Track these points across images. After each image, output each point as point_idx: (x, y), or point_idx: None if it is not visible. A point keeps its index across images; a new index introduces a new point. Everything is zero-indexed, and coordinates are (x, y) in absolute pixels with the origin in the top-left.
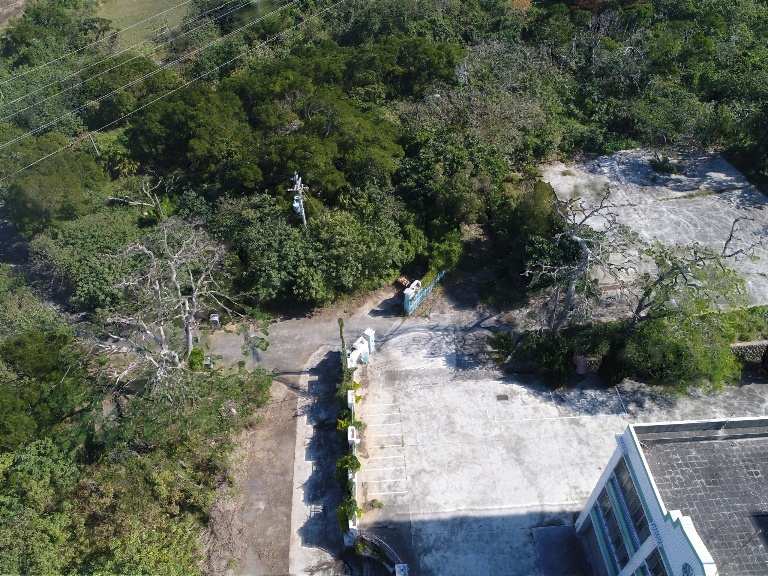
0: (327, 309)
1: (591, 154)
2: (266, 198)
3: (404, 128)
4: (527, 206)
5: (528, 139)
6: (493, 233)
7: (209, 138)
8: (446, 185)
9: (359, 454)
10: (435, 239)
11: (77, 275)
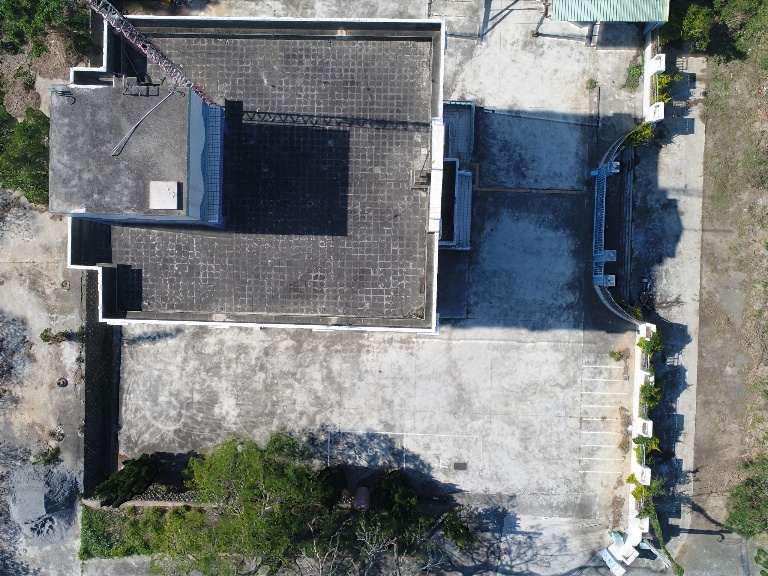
0: None
1: None
2: None
3: None
4: None
5: None
6: None
7: None
8: None
9: (630, 413)
10: None
11: None
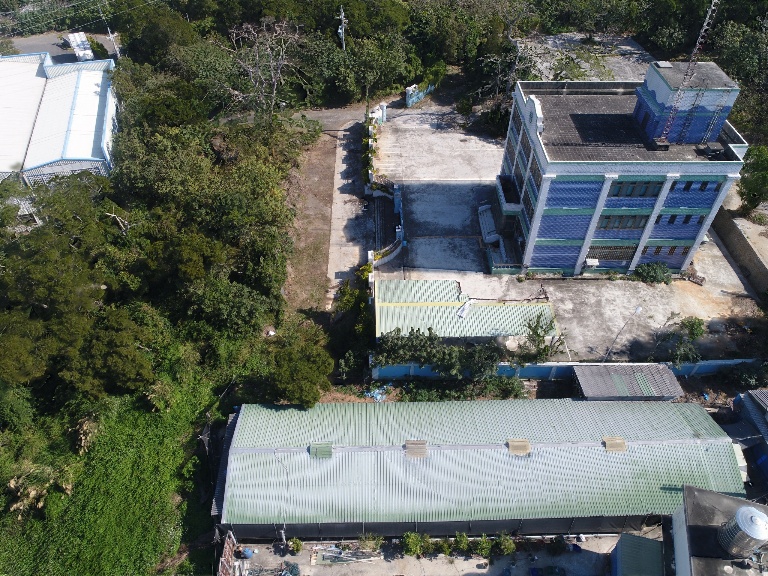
0: (355, 104)
1: (542, 34)
2: (318, 35)
3: (412, 14)
4: (489, 43)
5: (497, 17)
6: (468, 70)
7: (276, 10)
8: (437, 27)
9: (375, 158)
10: (428, 67)
11: (196, 71)
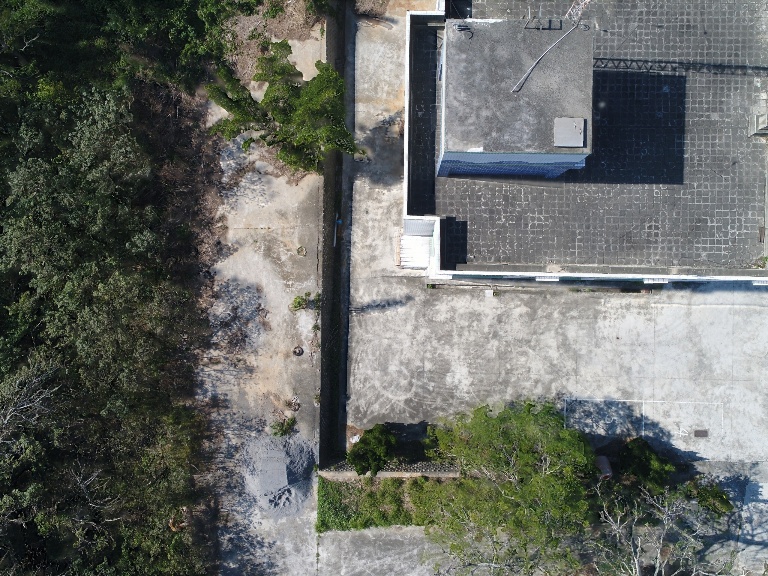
0: None
1: None
2: None
3: None
4: None
5: None
6: None
7: None
8: None
9: None
10: None
11: None
